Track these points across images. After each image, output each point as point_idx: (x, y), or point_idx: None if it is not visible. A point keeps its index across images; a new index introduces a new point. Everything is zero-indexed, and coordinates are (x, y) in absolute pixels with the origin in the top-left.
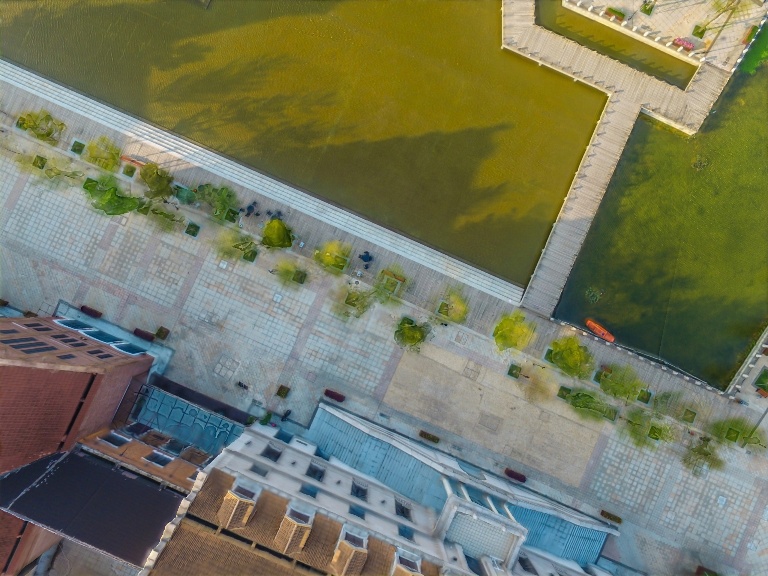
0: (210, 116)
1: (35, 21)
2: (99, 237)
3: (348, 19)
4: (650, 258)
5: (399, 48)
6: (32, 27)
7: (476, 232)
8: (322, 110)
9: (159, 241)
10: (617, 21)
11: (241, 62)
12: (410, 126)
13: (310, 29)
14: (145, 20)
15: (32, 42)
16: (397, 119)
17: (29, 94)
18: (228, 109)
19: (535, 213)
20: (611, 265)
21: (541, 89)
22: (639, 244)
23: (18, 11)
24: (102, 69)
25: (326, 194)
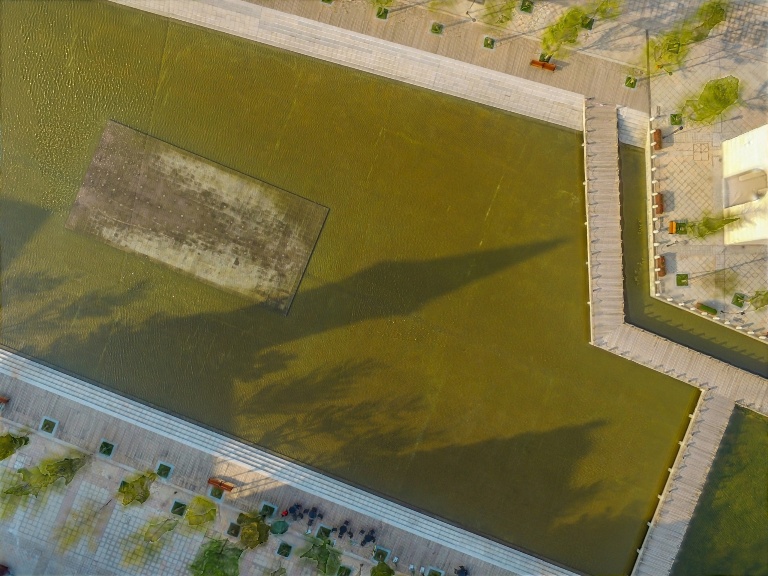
0: (295, 427)
1: (111, 336)
2: (190, 562)
3: (431, 319)
4: (746, 550)
5: (485, 347)
6: (109, 343)
7: (570, 534)
8: (409, 415)
9: (251, 563)
10: (708, 315)
11: (324, 369)
12: (499, 428)
13: (393, 331)
14: (224, 330)
15: (109, 359)
16: (485, 421)
17: (111, 417)
18: (313, 419)
19: (629, 511)
20: (707, 560)
21: (631, 383)
22: (734, 537)
23: (93, 327)
24: (182, 383)
25: (417, 502)
